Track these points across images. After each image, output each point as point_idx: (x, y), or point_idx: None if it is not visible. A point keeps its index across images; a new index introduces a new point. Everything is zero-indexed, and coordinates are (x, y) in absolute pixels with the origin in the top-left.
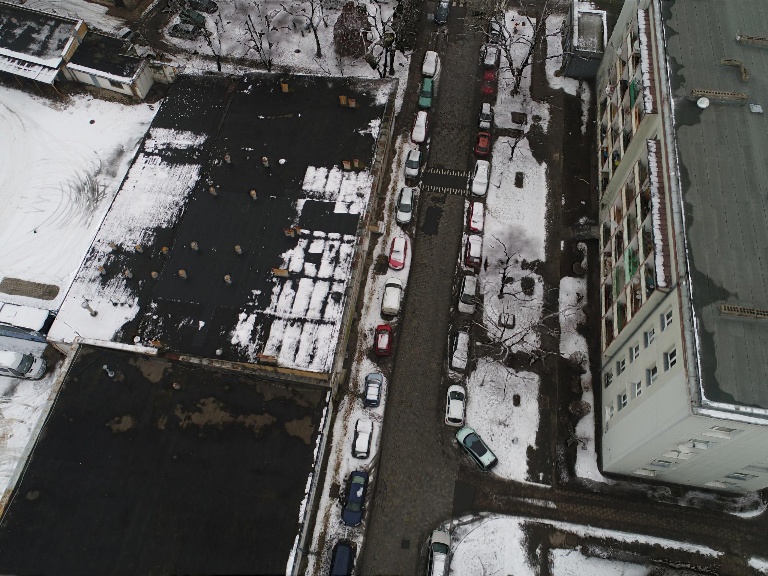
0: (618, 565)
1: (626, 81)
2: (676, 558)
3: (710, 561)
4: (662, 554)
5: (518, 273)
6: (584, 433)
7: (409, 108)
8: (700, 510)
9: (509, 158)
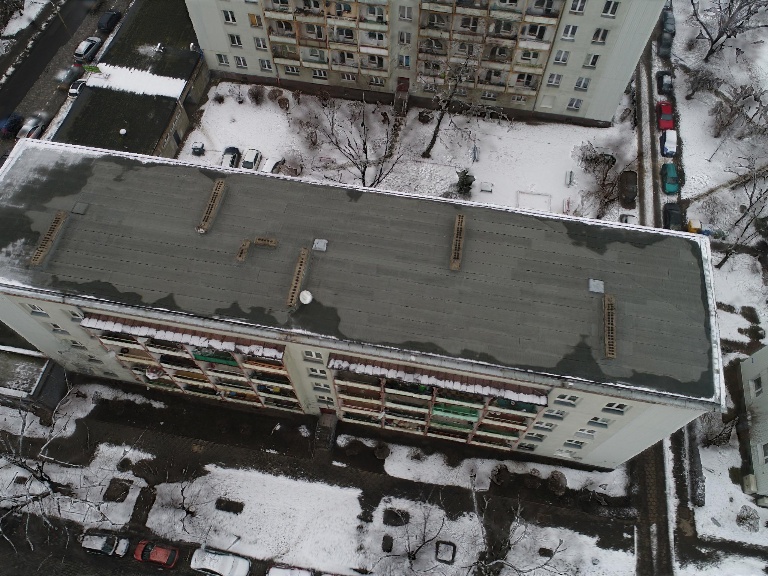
0: None
1: (162, 356)
2: None
3: None
4: None
5: (377, 528)
6: (576, 481)
7: None
8: None
9: (190, 516)
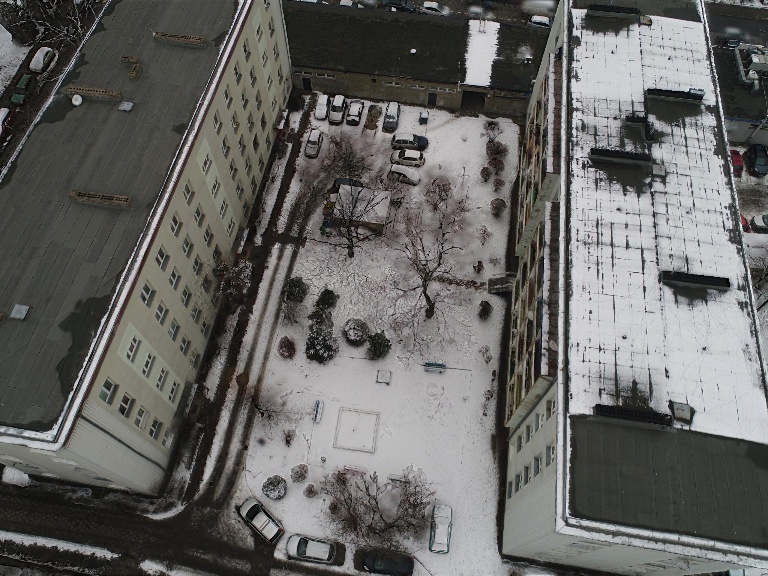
0: (2, 568)
1: None
2: (67, 561)
3: (101, 563)
4: (54, 557)
5: None
6: None
7: (3, 105)
8: (114, 512)
9: None
